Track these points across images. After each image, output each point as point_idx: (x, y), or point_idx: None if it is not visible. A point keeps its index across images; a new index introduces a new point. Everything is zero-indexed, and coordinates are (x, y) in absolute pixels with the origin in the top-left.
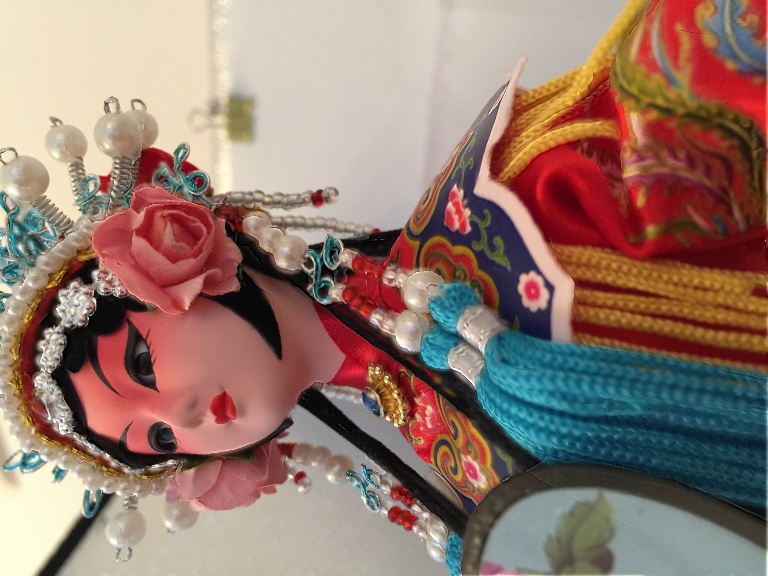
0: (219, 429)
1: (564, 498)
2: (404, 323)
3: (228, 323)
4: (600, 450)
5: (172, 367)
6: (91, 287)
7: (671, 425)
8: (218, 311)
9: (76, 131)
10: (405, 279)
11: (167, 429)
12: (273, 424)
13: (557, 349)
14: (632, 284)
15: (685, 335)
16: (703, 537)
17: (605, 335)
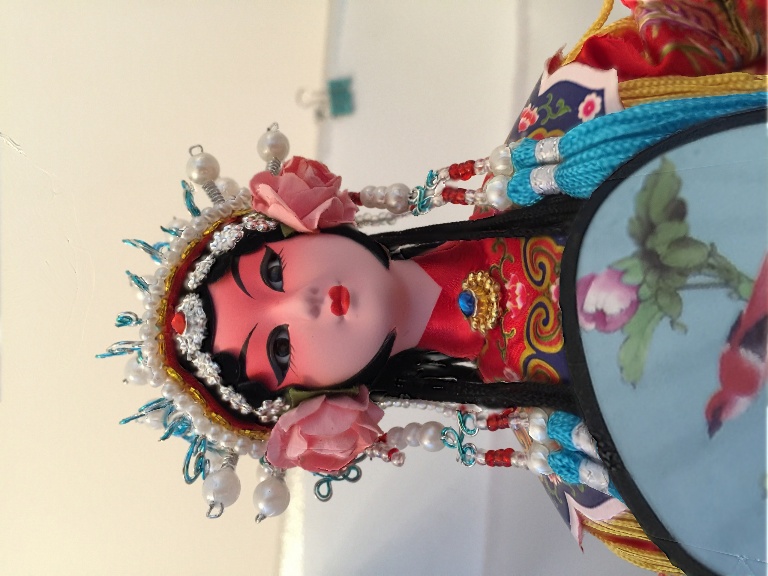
0: (332, 325)
1: (635, 180)
2: (493, 183)
3: (346, 244)
4: None
5: (299, 267)
6: (241, 225)
7: (708, 119)
8: None
9: None
10: None
11: (283, 344)
12: (378, 331)
13: None
14: (662, 90)
15: None
16: (748, 140)
17: None
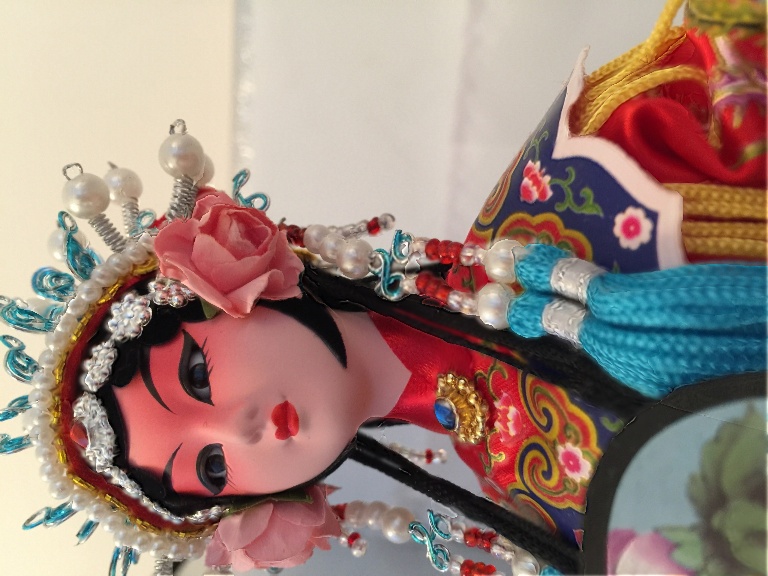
0: (278, 448)
1: (707, 423)
2: (488, 295)
3: (290, 330)
4: (739, 367)
5: (230, 374)
6: (147, 297)
7: None
8: (279, 318)
9: (133, 174)
10: (485, 253)
11: (217, 458)
12: (336, 446)
13: (670, 273)
14: (737, 211)
15: None
16: None
17: (717, 263)
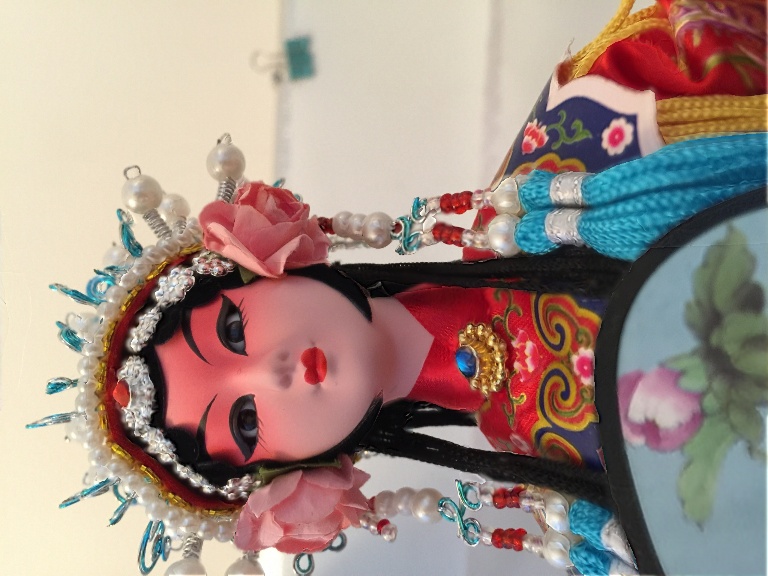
0: (307, 395)
1: (693, 251)
2: (496, 224)
3: (319, 291)
4: None
5: (264, 324)
6: (191, 268)
7: None
8: (310, 282)
9: None
10: None
11: (249, 415)
12: (362, 397)
13: None
14: (708, 113)
15: None
16: None
17: None
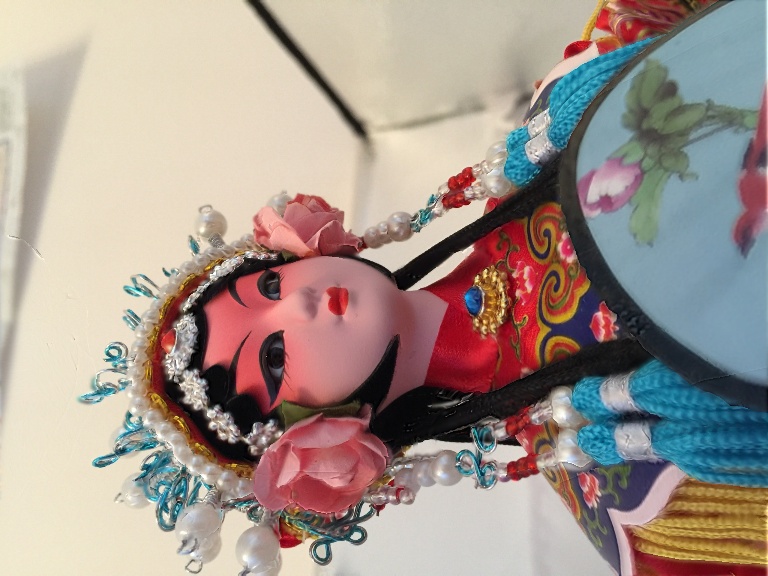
0: (330, 325)
1: (623, 85)
2: (490, 172)
3: None
4: None
5: (297, 275)
6: (242, 256)
7: None
8: None
9: None
10: None
11: (278, 355)
12: (380, 334)
13: None
14: None
15: None
16: (725, 16)
17: None
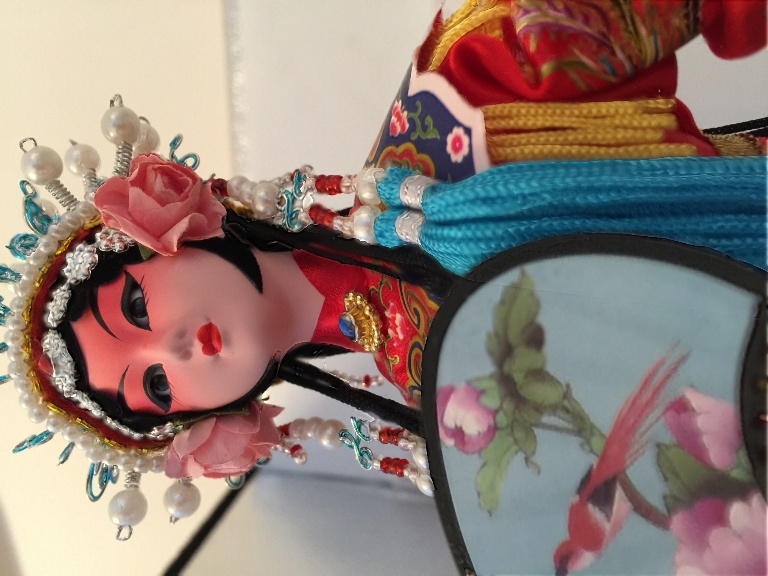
0: (207, 364)
1: (494, 289)
2: (360, 216)
3: (213, 265)
4: None
5: (163, 303)
6: (94, 245)
7: (578, 206)
8: (205, 256)
9: (90, 148)
10: None
11: (162, 378)
12: (259, 361)
13: (479, 177)
14: (540, 123)
15: (590, 153)
16: (610, 273)
17: None
